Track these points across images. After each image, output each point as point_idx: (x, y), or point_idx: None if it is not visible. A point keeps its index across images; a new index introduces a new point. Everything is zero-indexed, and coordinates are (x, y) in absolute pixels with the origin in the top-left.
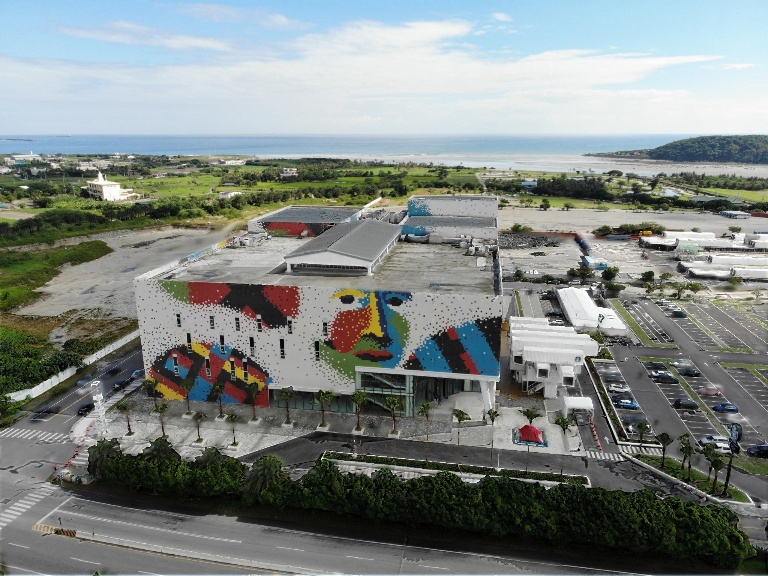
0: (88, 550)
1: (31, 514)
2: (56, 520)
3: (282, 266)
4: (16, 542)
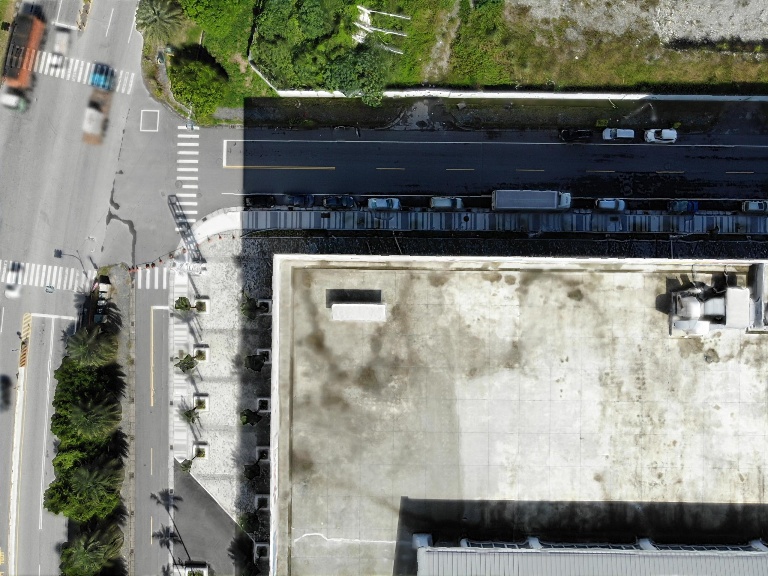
0: (7, 390)
1: (44, 296)
2: (39, 330)
3: (470, 508)
4: (5, 313)
